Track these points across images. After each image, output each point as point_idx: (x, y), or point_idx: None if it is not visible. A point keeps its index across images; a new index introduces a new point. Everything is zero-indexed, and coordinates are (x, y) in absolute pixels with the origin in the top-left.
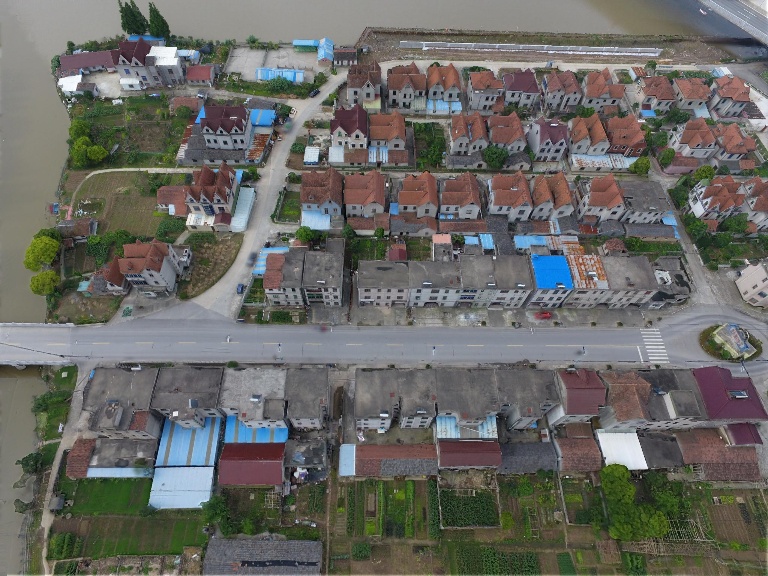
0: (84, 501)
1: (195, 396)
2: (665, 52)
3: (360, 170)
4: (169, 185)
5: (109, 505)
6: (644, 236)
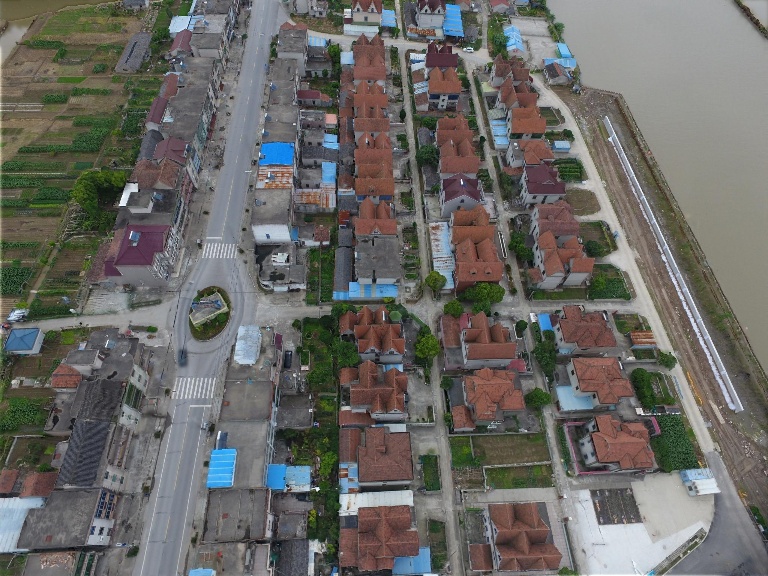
0: (186, 5)
1: (214, 7)
2: (750, 425)
3: (409, 85)
4: (384, 6)
5: (181, 11)
6: (335, 262)
